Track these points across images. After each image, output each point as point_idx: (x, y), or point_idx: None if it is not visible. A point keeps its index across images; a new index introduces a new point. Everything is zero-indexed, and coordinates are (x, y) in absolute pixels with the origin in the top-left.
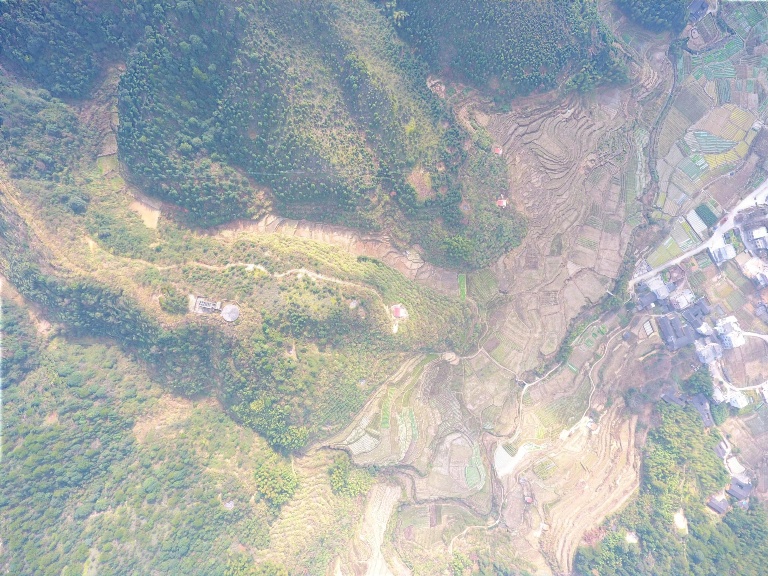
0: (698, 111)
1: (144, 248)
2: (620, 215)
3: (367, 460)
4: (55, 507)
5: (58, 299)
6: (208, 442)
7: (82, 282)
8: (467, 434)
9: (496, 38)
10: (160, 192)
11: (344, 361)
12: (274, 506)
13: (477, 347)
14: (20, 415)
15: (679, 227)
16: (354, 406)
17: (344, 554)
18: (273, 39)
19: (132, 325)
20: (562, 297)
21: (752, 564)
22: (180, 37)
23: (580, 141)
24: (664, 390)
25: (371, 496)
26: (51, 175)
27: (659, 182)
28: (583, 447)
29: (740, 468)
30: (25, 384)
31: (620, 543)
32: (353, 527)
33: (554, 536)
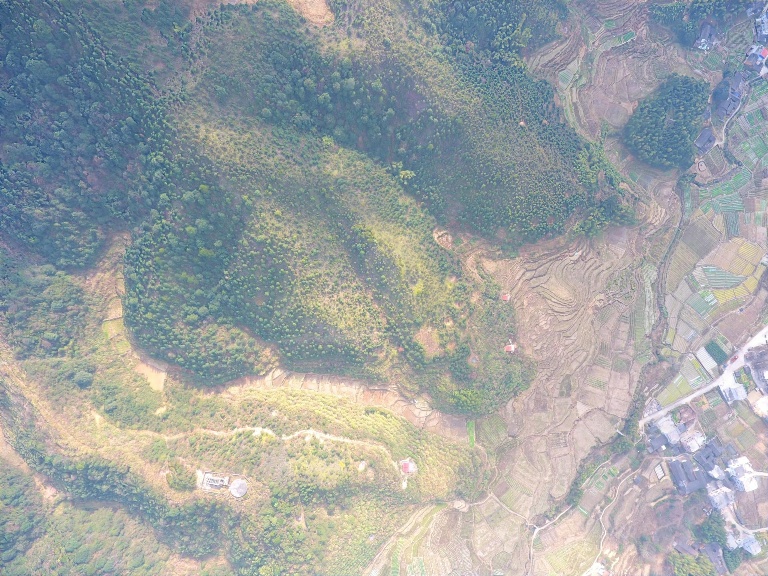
0: (706, 245)
1: (151, 418)
2: (629, 353)
3: None
4: None
5: (64, 476)
6: None
7: (89, 461)
8: None
9: (503, 196)
10: (166, 358)
11: (353, 522)
12: None
13: (487, 493)
14: None
15: (689, 364)
16: (363, 561)
17: None
18: (280, 218)
19: (139, 497)
20: (572, 438)
21: None
22: (186, 222)
23: (588, 282)
24: (676, 538)
25: None
26: (57, 350)
27: (668, 318)
28: None
29: None
30: (31, 555)
31: None
32: None
33: None
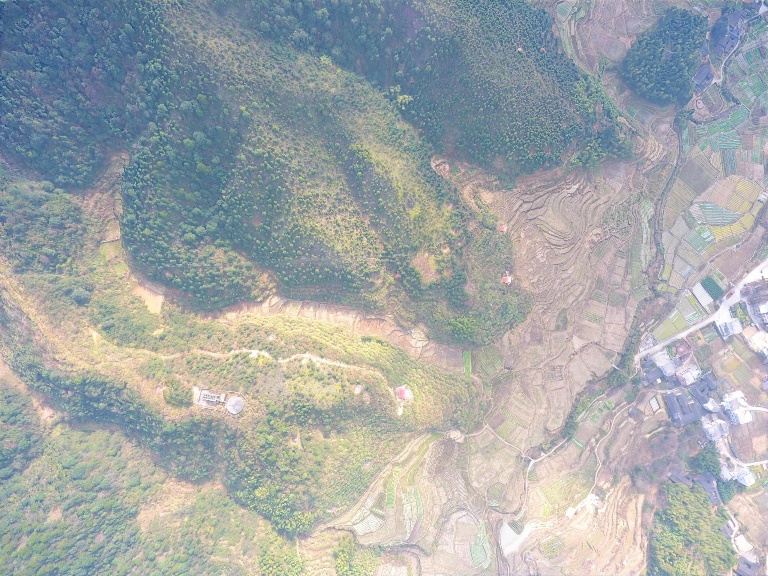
0: (703, 182)
1: (148, 337)
2: (625, 288)
3: (372, 540)
4: None
5: (62, 392)
6: (212, 529)
7: (86, 376)
8: (473, 512)
9: (501, 121)
10: (164, 279)
11: (349, 446)
12: None
13: (482, 424)
14: (24, 509)
15: (685, 300)
16: (359, 488)
17: None
18: (277, 133)
19: (136, 415)
20: (567, 372)
21: None
22: (184, 134)
23: (585, 216)
24: (671, 469)
25: None
26: (54, 267)
27: (664, 254)
28: (589, 525)
29: (748, 546)
30: (29, 473)
31: None
32: None
33: None
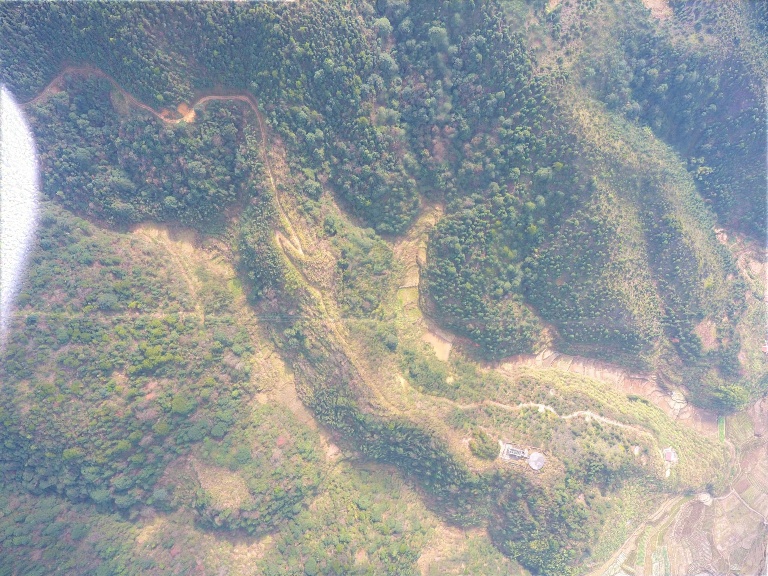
0: None
1: (447, 386)
2: None
3: None
4: None
5: (368, 435)
6: None
7: (398, 422)
8: (715, 575)
9: None
10: (461, 329)
11: (622, 505)
12: None
13: (729, 488)
14: (326, 548)
15: None
16: (617, 545)
17: None
18: (610, 202)
19: (432, 462)
20: None
21: None
22: (528, 198)
23: None
24: None
25: None
26: (370, 312)
27: None
28: None
29: None
30: (316, 510)
31: None
32: None
33: None
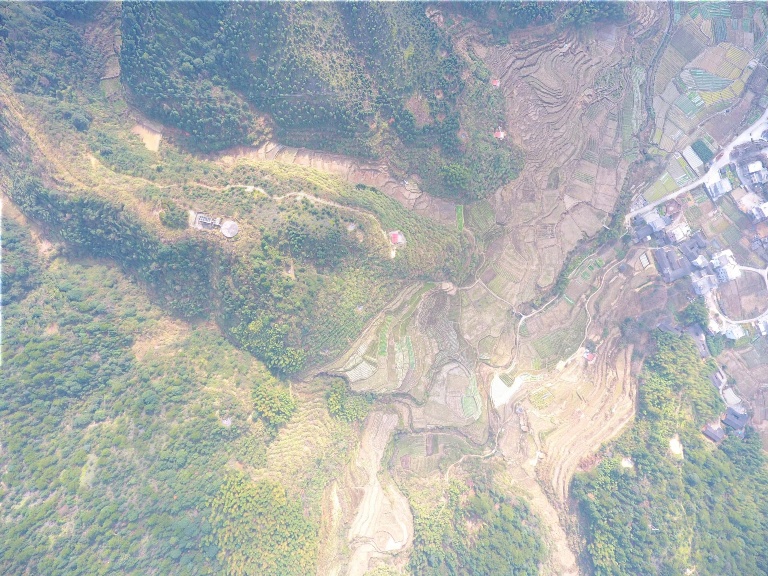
0: (694, 49)
1: (145, 167)
2: (617, 150)
3: (364, 387)
4: (54, 415)
5: (60, 214)
6: (206, 362)
7: (84, 196)
8: (464, 364)
9: None
10: (162, 113)
11: (342, 284)
12: (271, 425)
13: (474, 278)
14: (21, 327)
15: (675, 163)
16: (352, 332)
17: (341, 479)
18: None
19: (132, 242)
20: (559, 231)
21: (747, 489)
22: None
23: (577, 76)
24: (660, 320)
25: (368, 423)
26: (55, 92)
27: (655, 119)
28: (579, 377)
29: (736, 399)
30: (26, 301)
31: (616, 467)
32: (350, 452)
33: (550, 464)
